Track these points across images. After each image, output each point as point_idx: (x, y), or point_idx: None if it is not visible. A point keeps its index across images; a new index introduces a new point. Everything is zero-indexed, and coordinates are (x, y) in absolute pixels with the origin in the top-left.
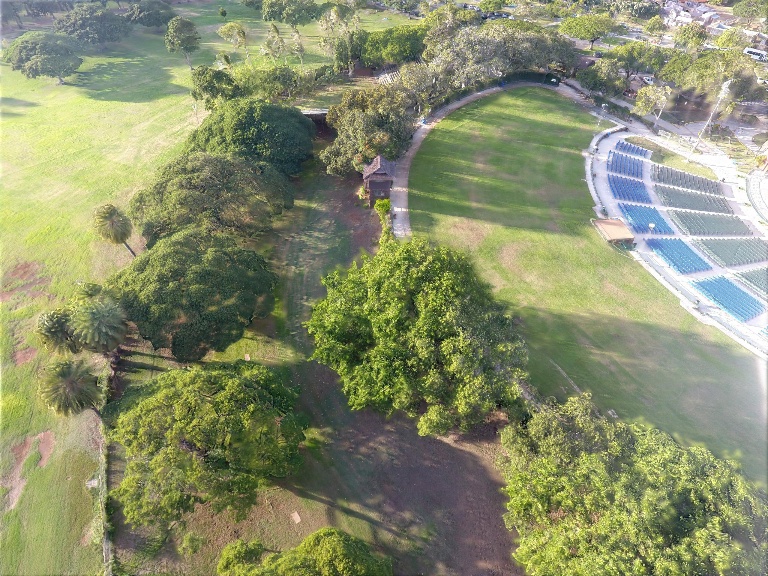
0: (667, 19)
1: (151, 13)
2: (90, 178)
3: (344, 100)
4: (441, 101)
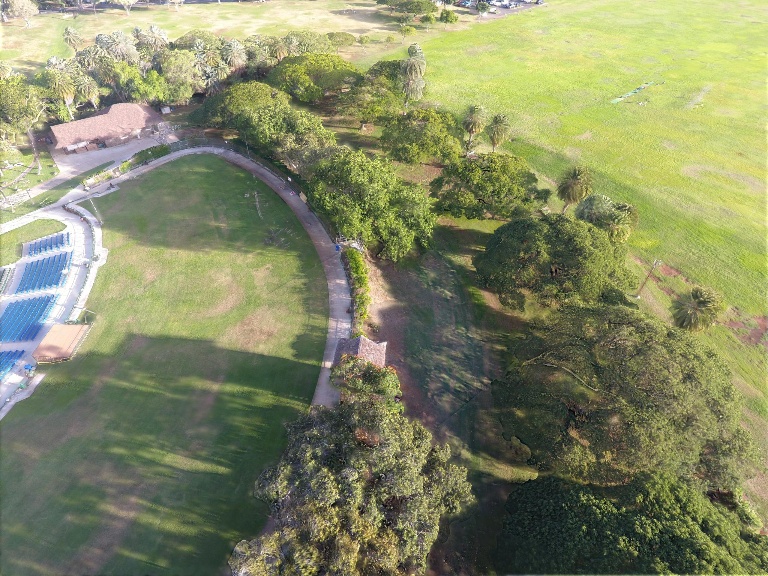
0: None
1: None
2: None
3: None
4: None
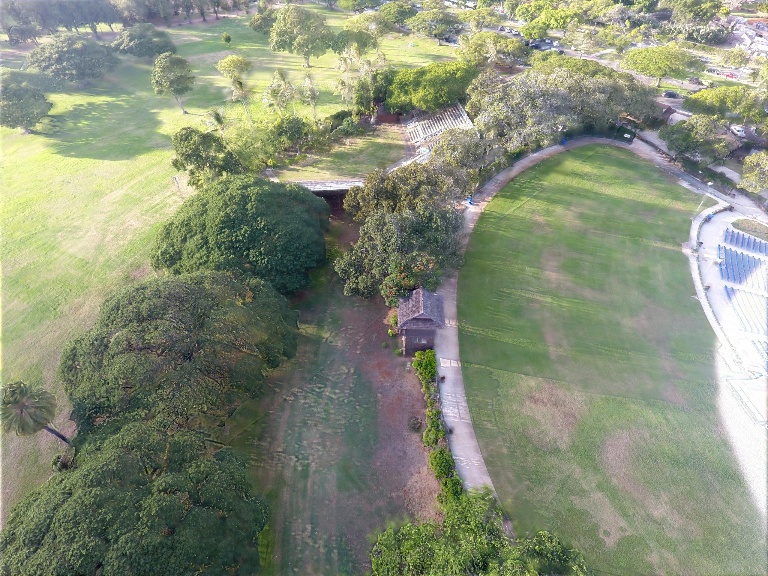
0: (740, 46)
1: (142, 42)
2: (33, 281)
3: (369, 188)
4: (490, 170)
